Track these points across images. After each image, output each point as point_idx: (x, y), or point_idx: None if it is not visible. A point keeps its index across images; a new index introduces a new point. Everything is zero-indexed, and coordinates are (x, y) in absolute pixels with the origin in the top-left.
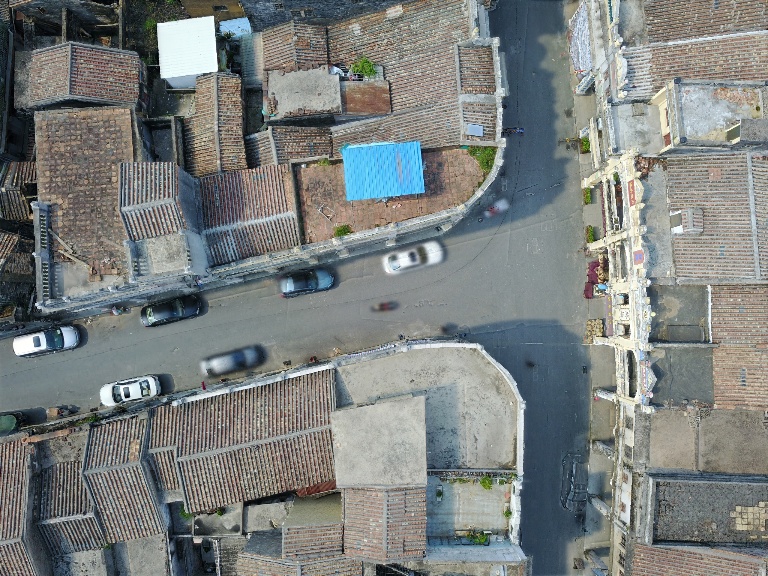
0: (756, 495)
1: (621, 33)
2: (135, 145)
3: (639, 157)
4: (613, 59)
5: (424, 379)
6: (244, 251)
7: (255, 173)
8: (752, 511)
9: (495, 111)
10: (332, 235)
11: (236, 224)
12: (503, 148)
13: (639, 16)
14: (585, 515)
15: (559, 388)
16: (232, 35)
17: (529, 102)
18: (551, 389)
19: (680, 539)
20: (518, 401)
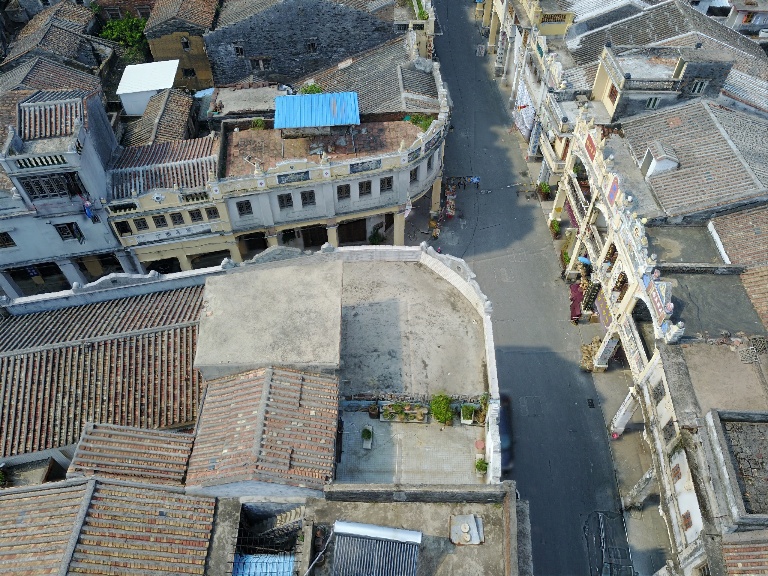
0: None
1: None
2: None
3: None
4: (549, 75)
5: (351, 294)
6: None
7: (185, 142)
8: None
9: None
10: None
11: (150, 165)
12: (446, 113)
13: (568, 59)
14: None
15: (560, 426)
16: None
17: (483, 167)
18: (548, 427)
19: None
20: (483, 313)
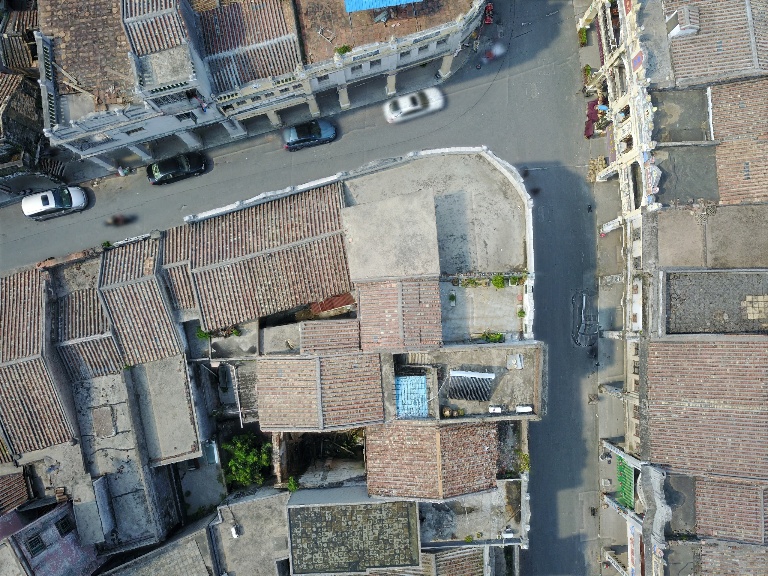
0: (766, 284)
1: None
2: None
3: None
4: None
5: None
6: (247, 78)
7: (254, 3)
8: (762, 300)
9: None
10: None
11: (238, 49)
12: None
13: None
14: (597, 351)
15: (565, 228)
16: None
17: None
18: (557, 229)
19: (693, 331)
20: (526, 203)
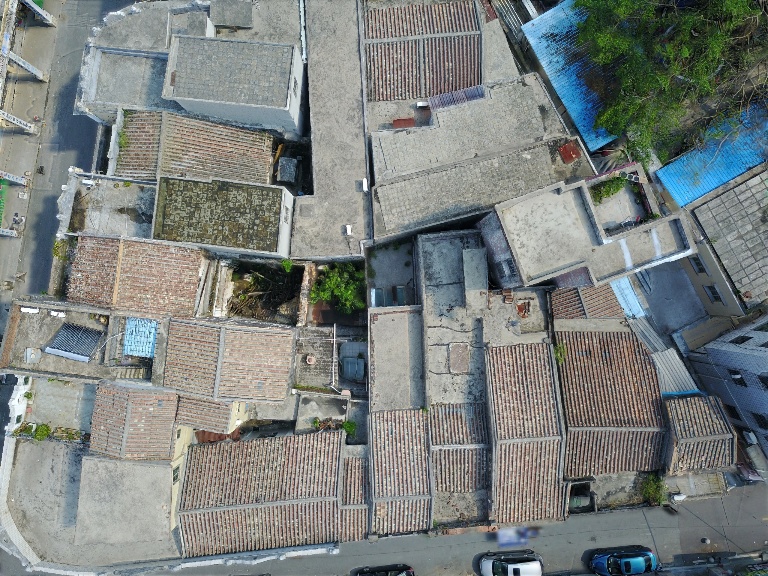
0: None
1: None
2: None
3: None
4: None
5: None
6: None
7: None
8: None
9: None
10: None
11: None
12: None
13: None
14: None
15: None
16: None
17: None
18: None
19: None
20: (3, 504)
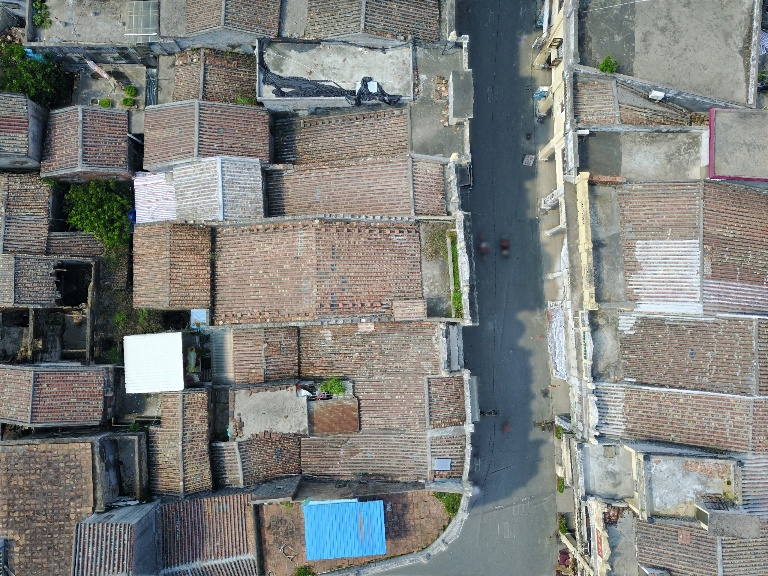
0: None
1: (595, 364)
2: (95, 479)
3: (608, 507)
4: None
5: None
6: None
7: (217, 503)
8: None
9: (464, 441)
10: (293, 575)
11: (195, 564)
12: None
13: (614, 347)
14: None
15: None
16: (202, 331)
17: (505, 380)
18: None
19: None
20: None
